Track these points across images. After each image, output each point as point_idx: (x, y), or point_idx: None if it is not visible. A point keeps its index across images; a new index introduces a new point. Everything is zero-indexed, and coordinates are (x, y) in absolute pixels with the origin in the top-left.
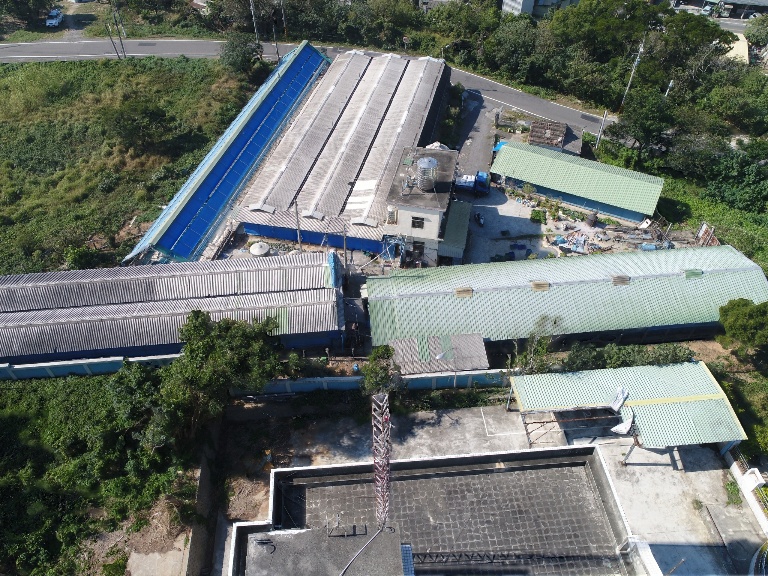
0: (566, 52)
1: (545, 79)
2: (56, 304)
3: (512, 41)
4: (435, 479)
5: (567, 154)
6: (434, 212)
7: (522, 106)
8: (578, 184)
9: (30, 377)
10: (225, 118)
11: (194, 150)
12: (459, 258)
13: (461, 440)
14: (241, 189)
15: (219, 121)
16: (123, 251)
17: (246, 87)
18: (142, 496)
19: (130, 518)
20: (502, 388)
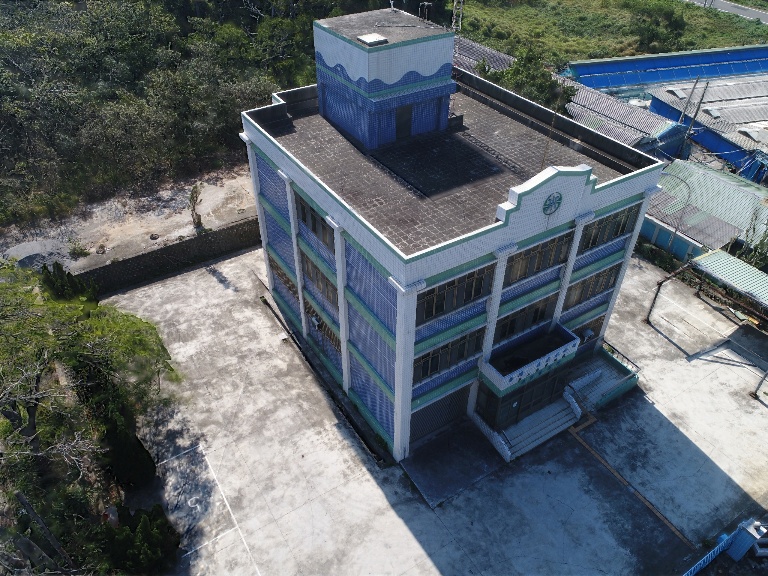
0: None
1: None
2: None
3: None
4: (529, 128)
5: None
6: None
7: None
8: None
9: None
10: None
11: None
12: None
13: (626, 274)
14: None
15: None
16: None
17: None
18: None
19: None
20: (715, 284)
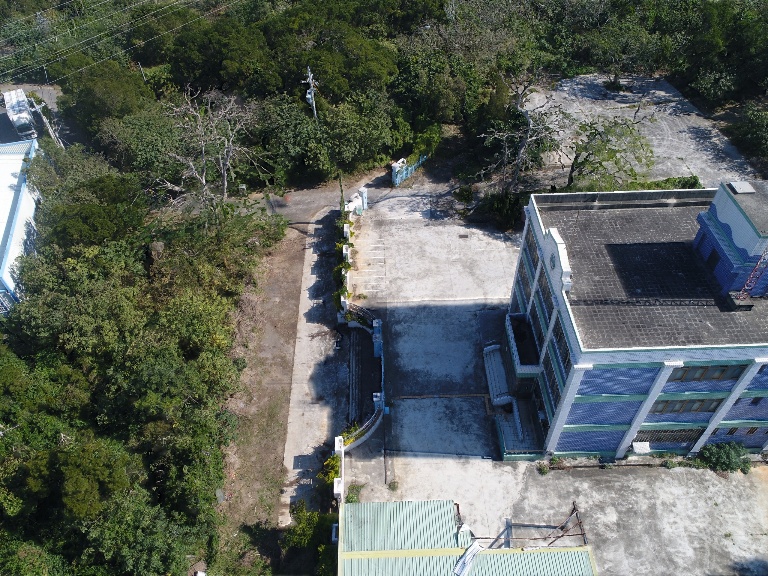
0: None
1: None
2: None
3: None
4: None
5: None
6: None
7: None
8: None
9: None
10: None
11: None
12: None
13: (640, 572)
14: None
15: None
16: None
17: None
18: None
19: None
20: None
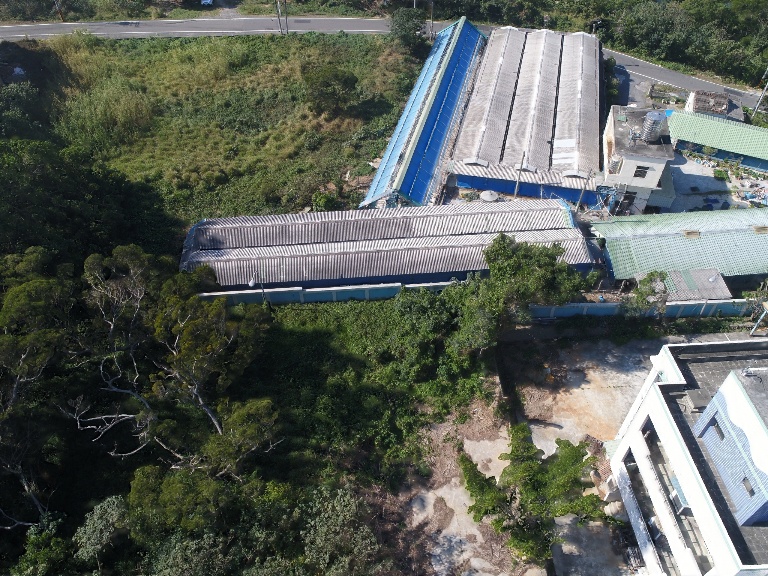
0: (700, 31)
1: (684, 55)
2: (326, 239)
3: (651, 19)
4: None
5: (733, 121)
6: (661, 161)
7: (667, 80)
8: (754, 146)
9: (315, 301)
10: (402, 86)
11: (382, 114)
12: (667, 208)
13: None
14: (446, 147)
15: (397, 89)
16: (357, 198)
17: (410, 60)
18: (458, 395)
19: (454, 413)
20: (740, 317)
